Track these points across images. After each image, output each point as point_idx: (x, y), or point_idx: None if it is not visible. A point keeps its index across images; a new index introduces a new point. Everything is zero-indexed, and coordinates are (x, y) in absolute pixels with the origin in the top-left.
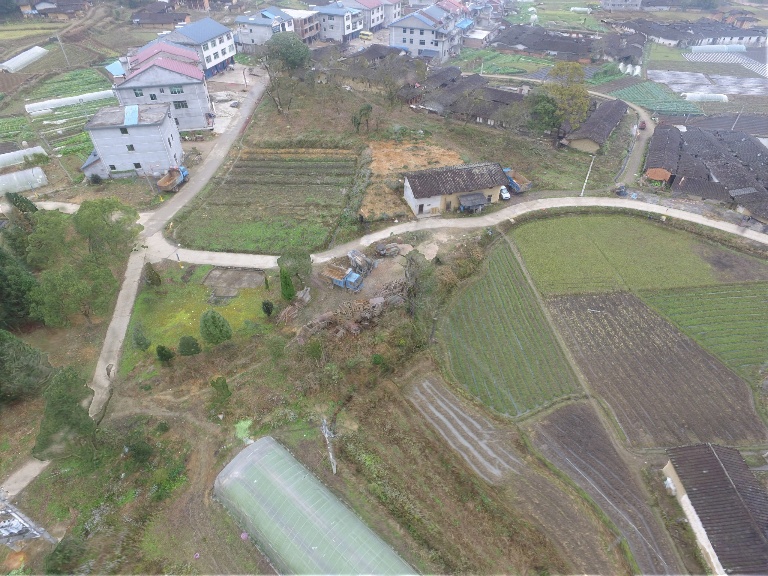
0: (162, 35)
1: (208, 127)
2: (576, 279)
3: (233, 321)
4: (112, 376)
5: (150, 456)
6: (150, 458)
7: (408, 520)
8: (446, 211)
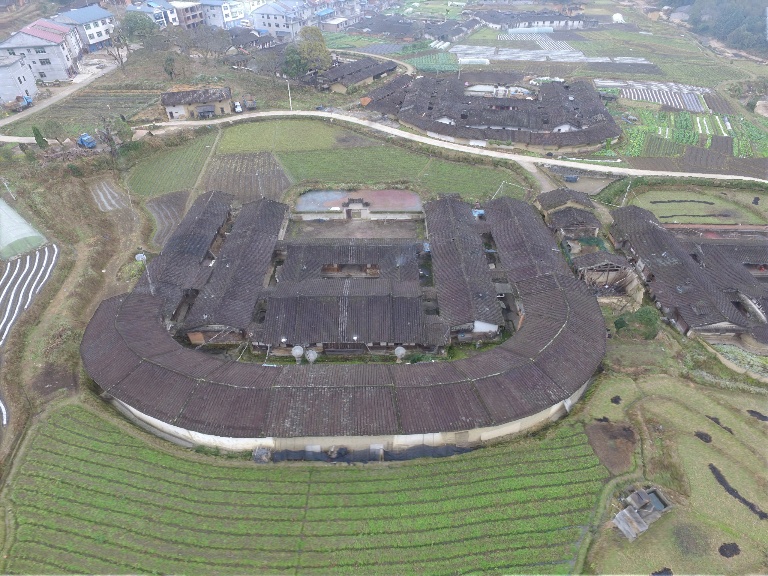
0: (54, 18)
1: (69, 79)
2: (244, 147)
3: None
4: None
5: None
6: None
7: (40, 213)
8: (191, 117)
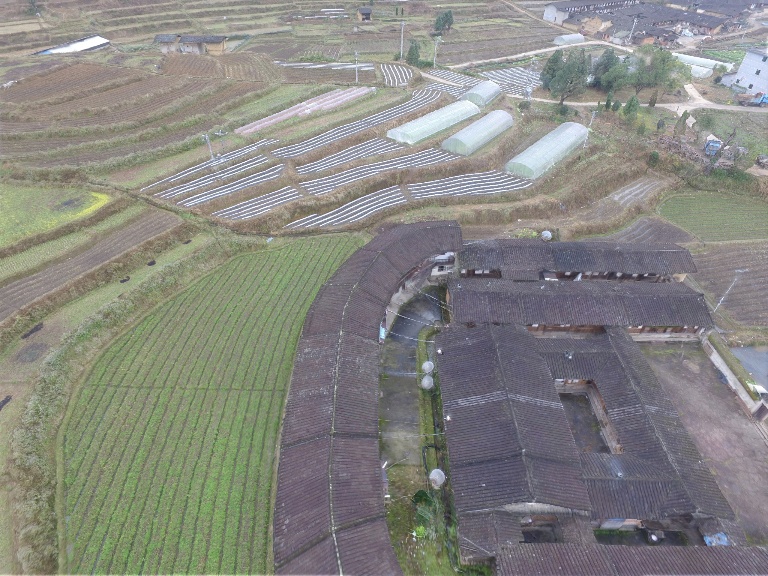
0: None
1: None
2: None
3: (646, 124)
4: (591, 105)
5: (564, 115)
6: (563, 116)
7: None
8: None
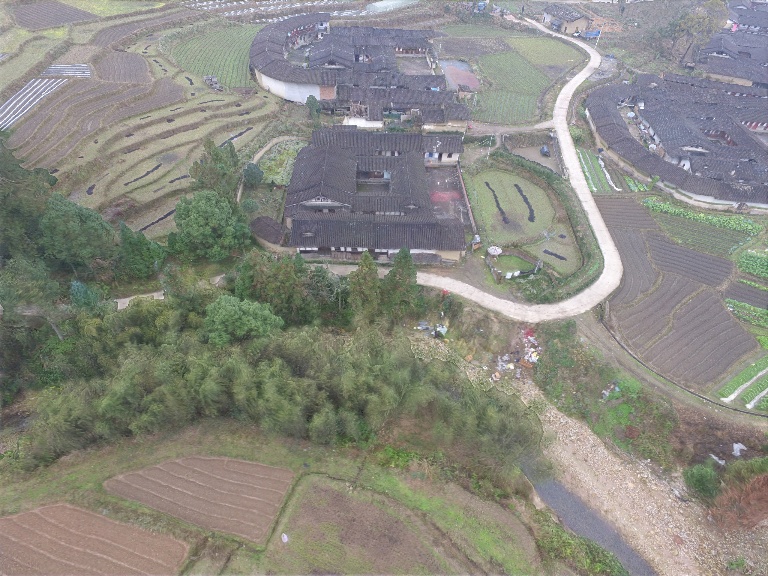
0: None
1: None
2: (517, 43)
3: None
4: None
5: None
6: None
7: None
8: (550, 26)
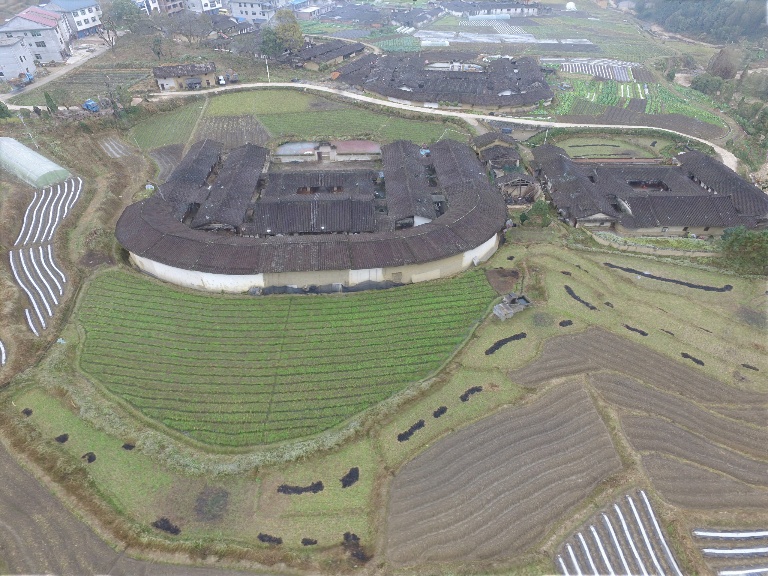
0: (43, 6)
1: (63, 61)
2: None
3: None
4: None
5: None
6: None
7: (61, 157)
8: (180, 89)
